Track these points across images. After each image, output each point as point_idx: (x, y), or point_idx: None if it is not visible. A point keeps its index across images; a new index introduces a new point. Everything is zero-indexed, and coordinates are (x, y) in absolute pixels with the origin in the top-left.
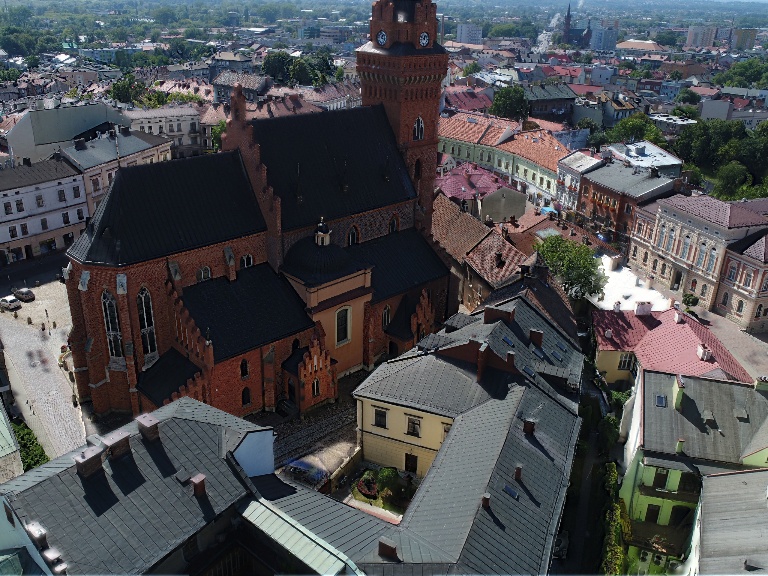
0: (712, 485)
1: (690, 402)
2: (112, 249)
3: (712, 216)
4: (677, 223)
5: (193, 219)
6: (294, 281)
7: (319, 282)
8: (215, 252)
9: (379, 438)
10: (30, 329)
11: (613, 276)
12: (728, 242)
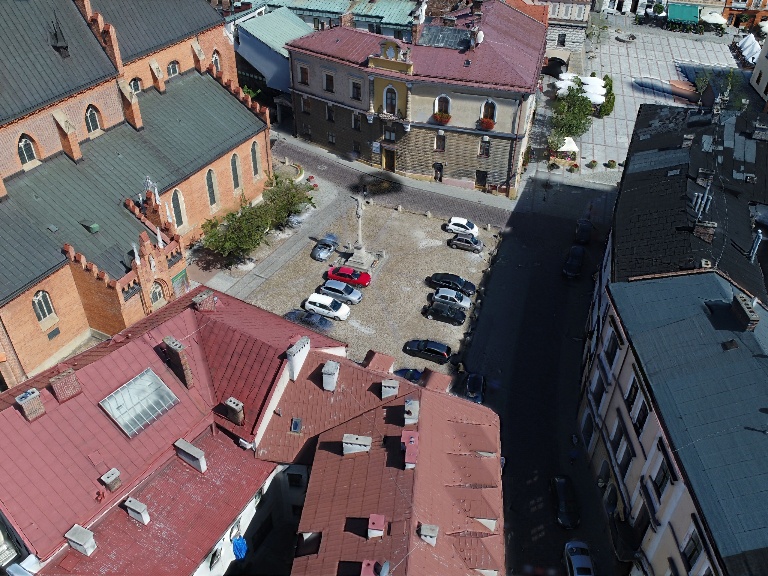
0: None
1: None
2: None
3: None
4: None
5: None
6: None
7: None
8: None
9: None
10: (386, 202)
11: None
12: None
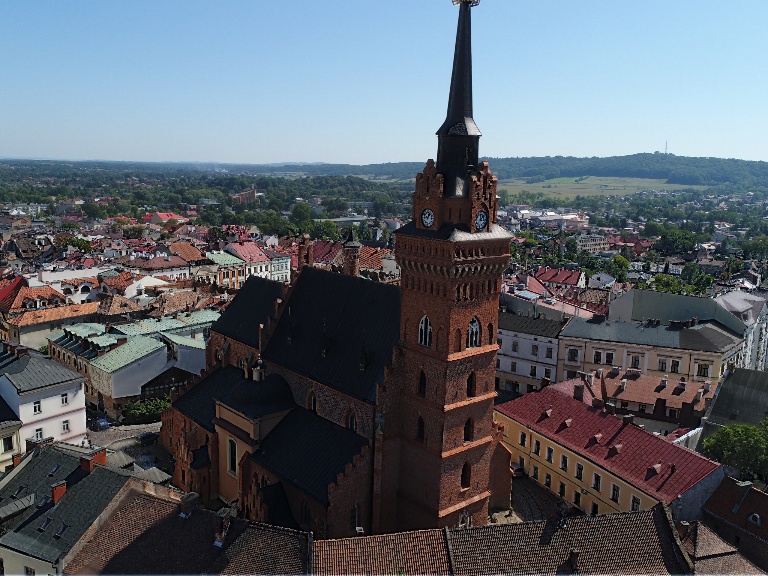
0: None
1: None
2: None
3: None
4: None
5: None
6: None
7: (221, 398)
8: None
9: None
10: None
11: None
12: None
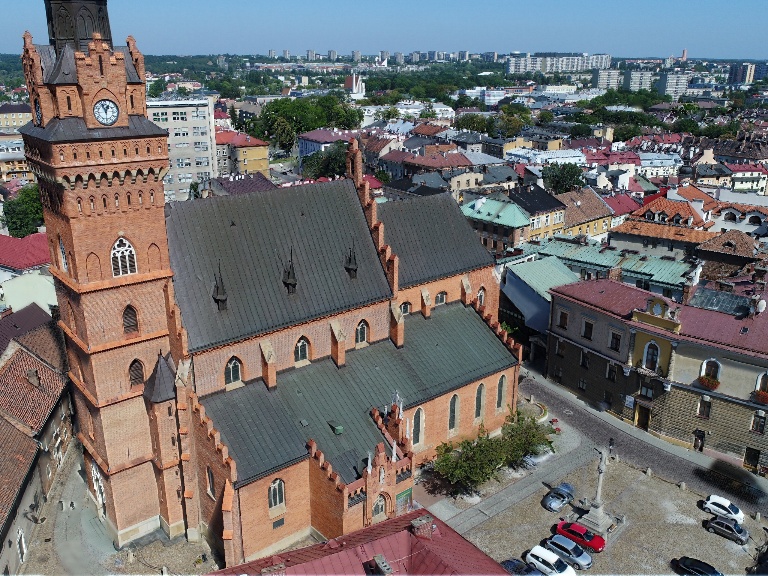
0: None
1: None
2: None
3: None
4: None
5: None
6: None
7: None
8: None
9: None
10: (633, 461)
11: None
12: None
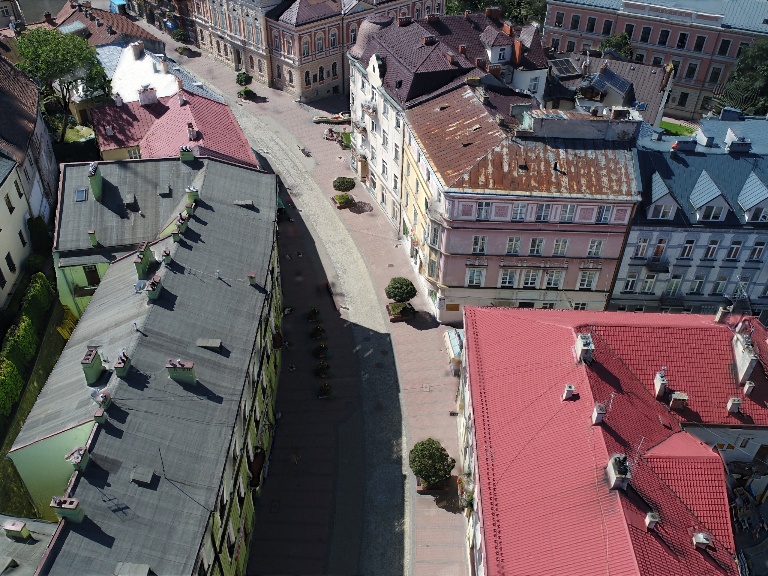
0: (111, 271)
1: (113, 189)
2: None
3: None
4: None
5: None
6: None
7: None
8: None
9: None
10: None
11: (136, 66)
12: (265, 9)
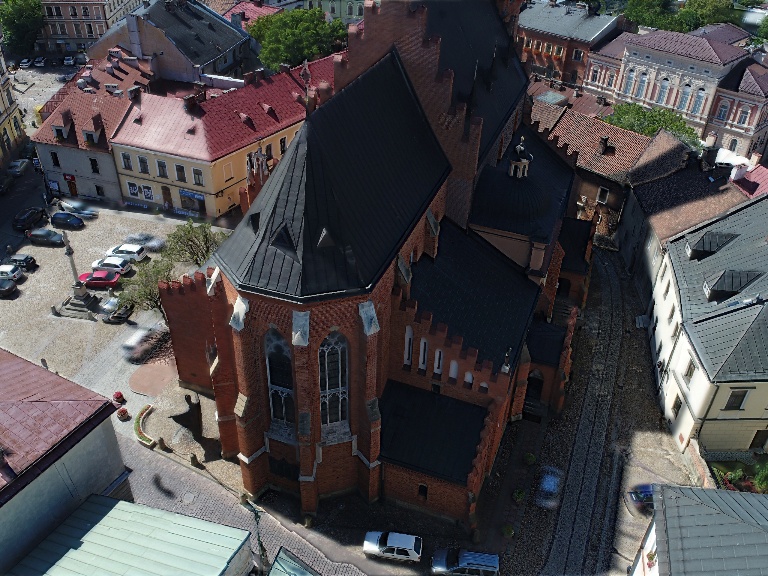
0: None
1: None
2: (341, 264)
3: (697, 54)
4: (652, 66)
5: (394, 179)
6: (496, 236)
7: None
8: (420, 223)
9: (725, 422)
10: None
11: None
12: (719, 80)
